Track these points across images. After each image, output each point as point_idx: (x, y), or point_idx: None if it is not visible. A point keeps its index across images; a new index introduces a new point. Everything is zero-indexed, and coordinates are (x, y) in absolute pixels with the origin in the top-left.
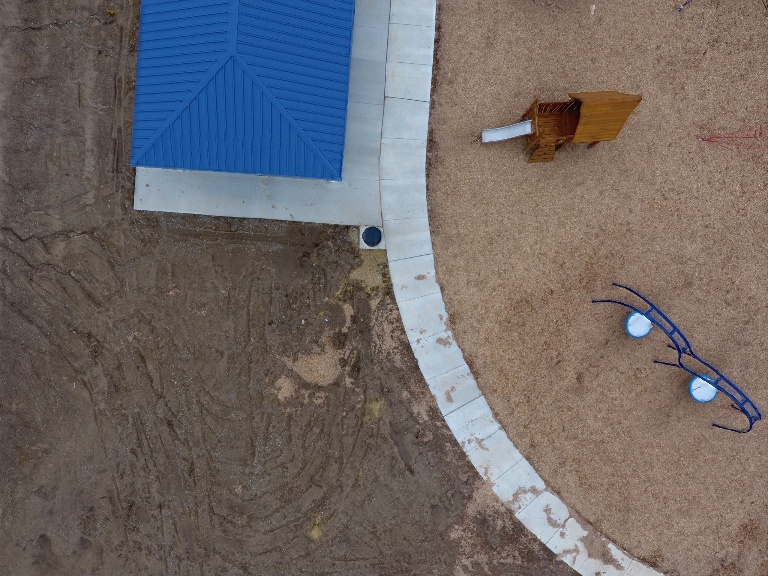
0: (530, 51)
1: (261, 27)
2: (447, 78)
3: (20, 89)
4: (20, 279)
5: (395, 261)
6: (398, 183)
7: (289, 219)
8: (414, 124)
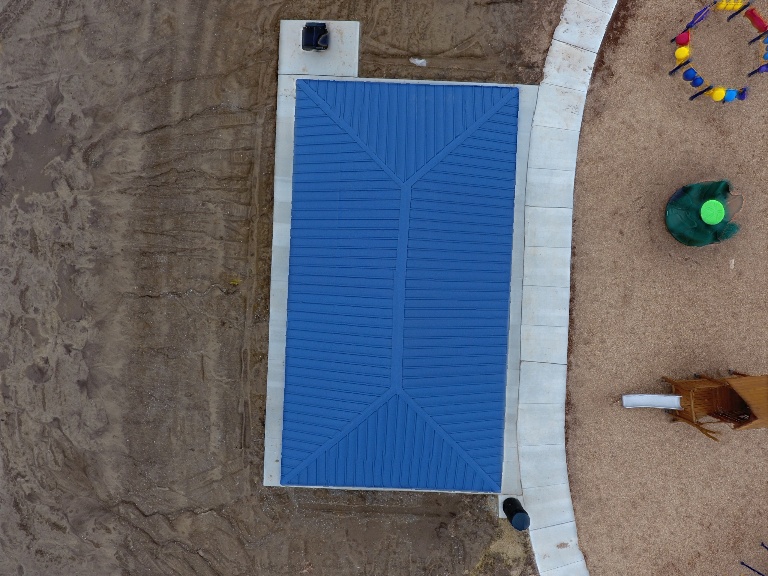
0: (669, 308)
1: (424, 357)
2: (583, 338)
3: (139, 358)
4: (145, 556)
5: (536, 530)
6: (537, 449)
7: (425, 490)
8: (552, 388)
